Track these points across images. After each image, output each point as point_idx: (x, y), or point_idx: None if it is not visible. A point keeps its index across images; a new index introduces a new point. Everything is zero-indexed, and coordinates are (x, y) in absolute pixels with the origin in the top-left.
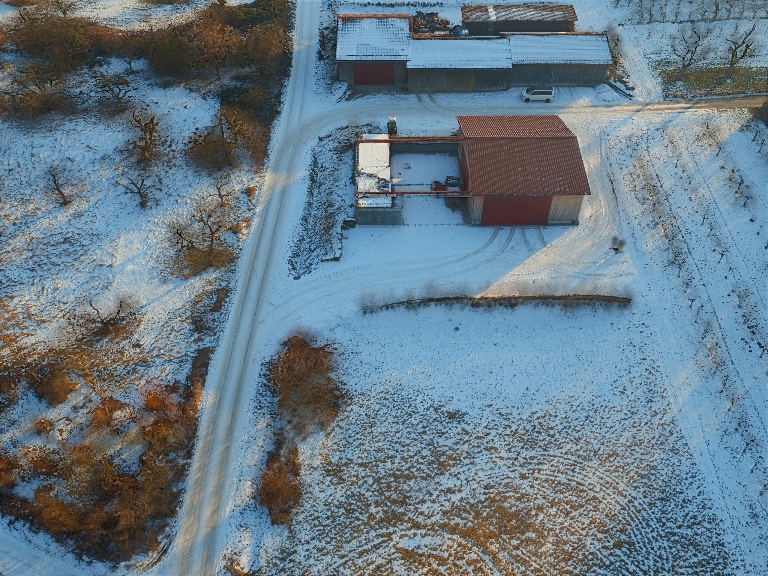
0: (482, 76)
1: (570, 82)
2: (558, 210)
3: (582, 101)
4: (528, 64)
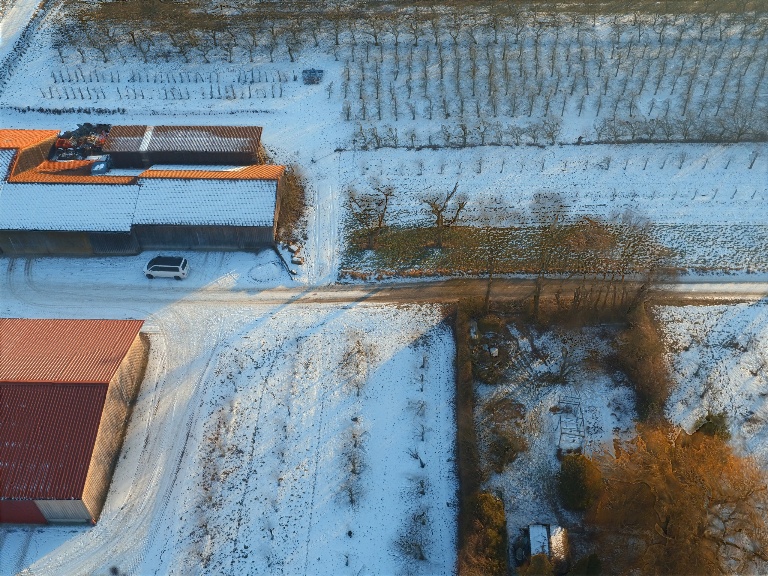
0: (97, 237)
1: (226, 245)
2: (53, 509)
3: (226, 279)
4: (154, 225)
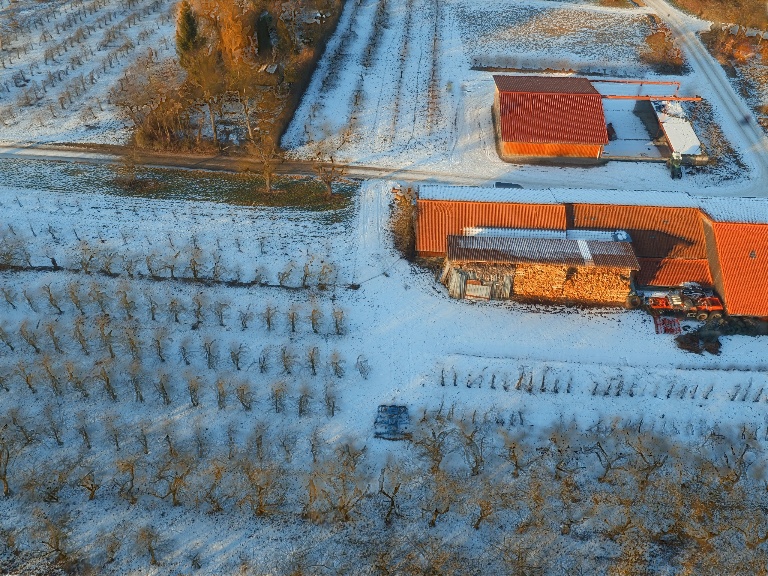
0: None
1: None
2: None
3: None
4: None
